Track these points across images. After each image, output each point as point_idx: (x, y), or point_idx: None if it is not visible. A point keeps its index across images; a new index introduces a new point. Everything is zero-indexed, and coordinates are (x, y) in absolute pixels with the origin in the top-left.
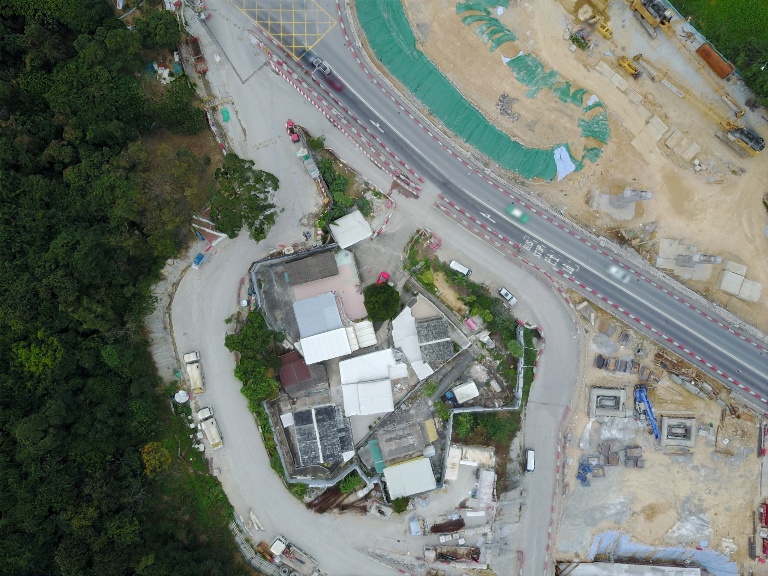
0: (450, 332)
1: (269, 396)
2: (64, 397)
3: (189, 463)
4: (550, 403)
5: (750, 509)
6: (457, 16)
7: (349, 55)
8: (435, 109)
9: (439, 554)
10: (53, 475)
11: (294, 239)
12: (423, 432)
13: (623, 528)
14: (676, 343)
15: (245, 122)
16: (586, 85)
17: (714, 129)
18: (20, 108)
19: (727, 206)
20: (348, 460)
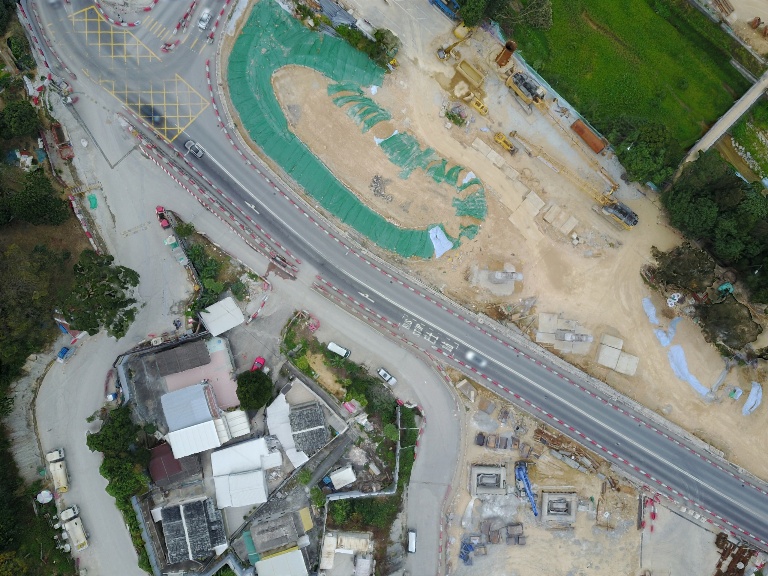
0: (327, 416)
1: (137, 492)
2: None
3: (52, 566)
4: (432, 482)
5: None
6: (329, 98)
7: (222, 136)
8: (311, 189)
9: None
10: None
11: (164, 328)
12: (298, 522)
13: None
14: (555, 418)
15: (114, 208)
16: (463, 162)
17: (591, 203)
18: None
19: (605, 279)
20: (221, 553)
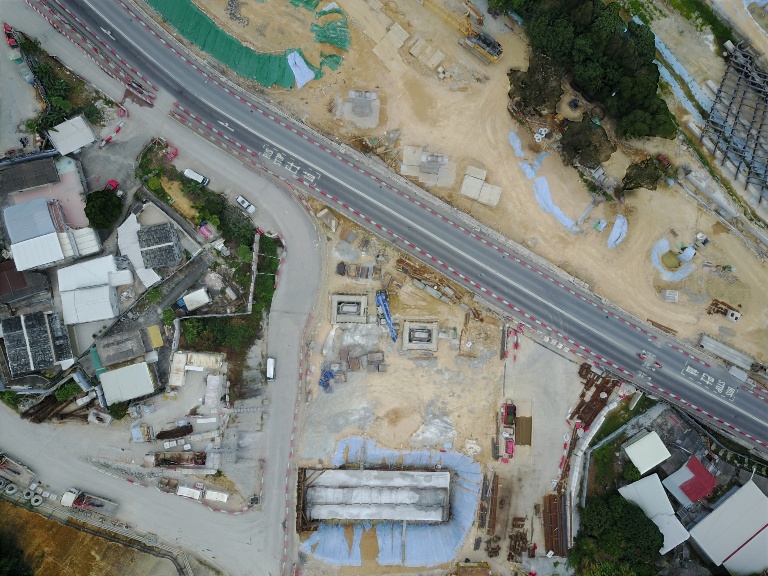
0: (181, 240)
1: None
2: None
3: None
4: (293, 311)
5: (493, 410)
6: None
7: None
8: (168, 16)
9: (161, 460)
10: None
11: (12, 146)
12: (147, 338)
13: (367, 433)
14: (418, 248)
15: None
16: None
17: (458, 37)
18: None
19: (471, 113)
20: None
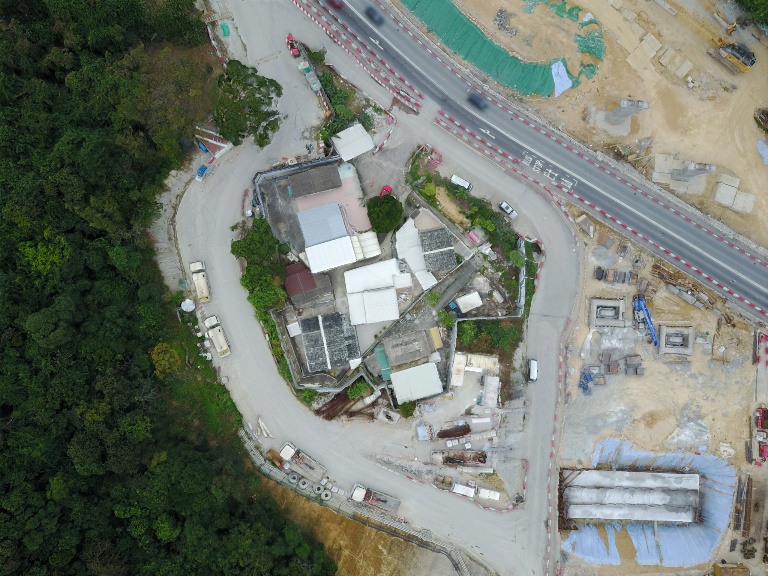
0: (453, 244)
1: (275, 305)
2: (72, 296)
3: (197, 371)
4: (551, 315)
5: (746, 414)
6: None
7: None
8: (434, 26)
9: (446, 458)
10: (63, 371)
11: (297, 152)
12: (428, 340)
13: (624, 435)
14: (673, 254)
15: (245, 38)
16: (581, 3)
17: (706, 47)
18: (19, 18)
19: (720, 121)
20: (355, 368)
